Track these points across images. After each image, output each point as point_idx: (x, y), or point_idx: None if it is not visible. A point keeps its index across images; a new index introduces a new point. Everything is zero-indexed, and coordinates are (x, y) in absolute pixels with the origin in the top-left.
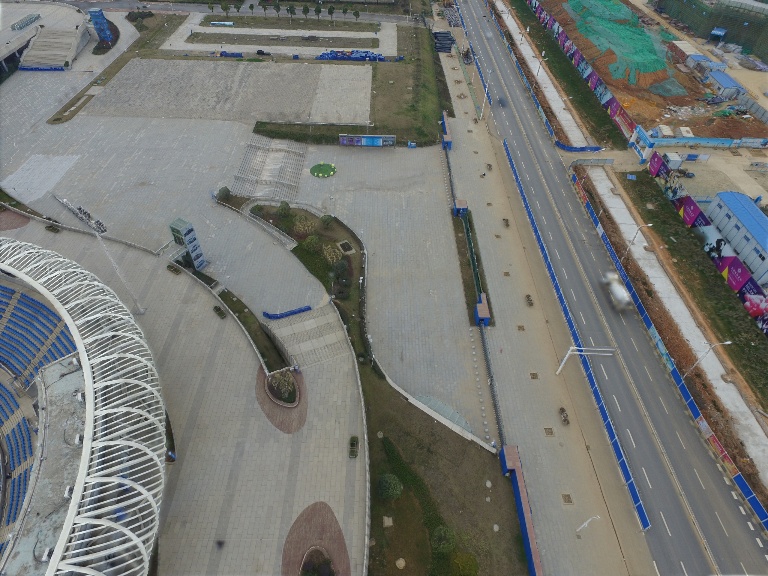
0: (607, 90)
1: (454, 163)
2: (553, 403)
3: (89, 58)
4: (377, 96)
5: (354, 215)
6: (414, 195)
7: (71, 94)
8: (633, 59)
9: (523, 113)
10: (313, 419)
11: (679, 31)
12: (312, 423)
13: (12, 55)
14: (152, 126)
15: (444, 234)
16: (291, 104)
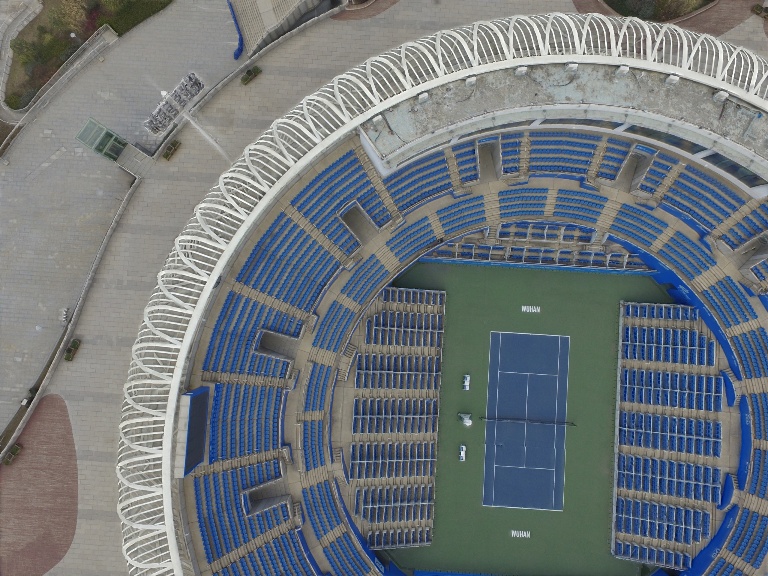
0: None
1: None
2: None
3: None
4: None
5: None
6: None
7: None
8: None
9: None
10: None
11: None
12: None
13: None
14: None
15: None
16: None
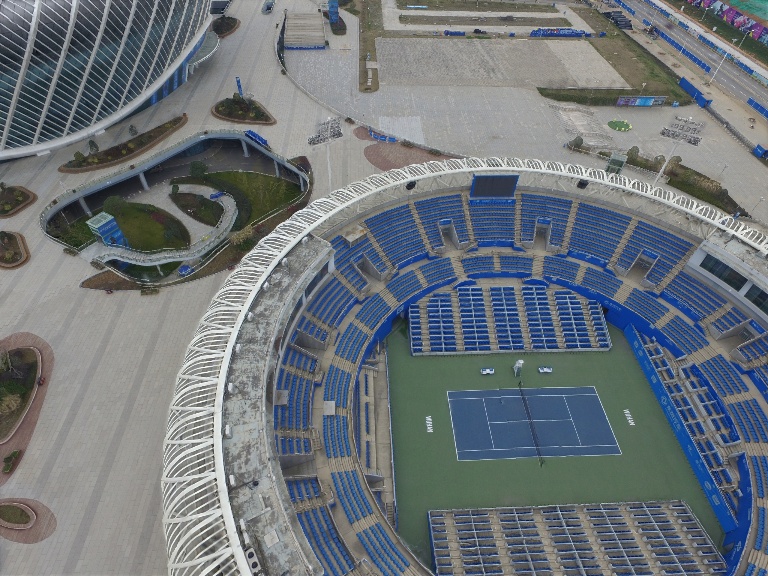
0: None
1: None
2: None
3: (335, 38)
4: (616, 65)
5: None
6: (711, 143)
7: (354, 68)
8: None
9: (739, 78)
10: None
11: None
12: None
13: None
14: (453, 93)
15: (763, 171)
16: (551, 73)
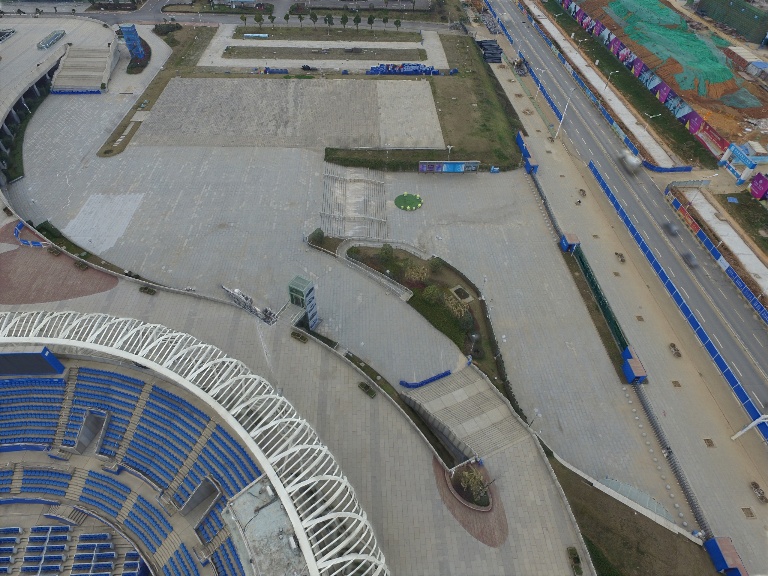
0: (684, 104)
1: (544, 189)
2: (740, 476)
3: (124, 78)
4: (444, 115)
5: (457, 254)
6: (513, 228)
7: (115, 121)
8: (700, 69)
9: (597, 129)
10: (516, 526)
11: (728, 35)
12: (516, 531)
13: (43, 78)
14: (214, 156)
15: (559, 273)
16: (357, 127)
